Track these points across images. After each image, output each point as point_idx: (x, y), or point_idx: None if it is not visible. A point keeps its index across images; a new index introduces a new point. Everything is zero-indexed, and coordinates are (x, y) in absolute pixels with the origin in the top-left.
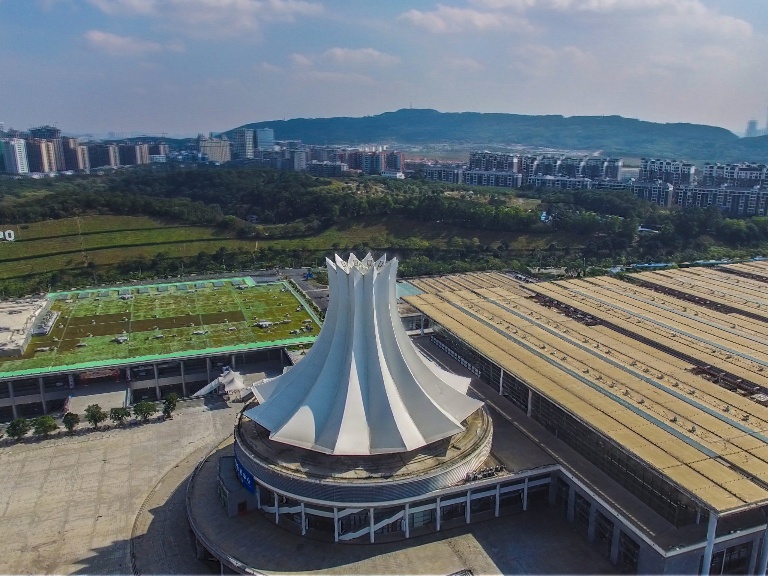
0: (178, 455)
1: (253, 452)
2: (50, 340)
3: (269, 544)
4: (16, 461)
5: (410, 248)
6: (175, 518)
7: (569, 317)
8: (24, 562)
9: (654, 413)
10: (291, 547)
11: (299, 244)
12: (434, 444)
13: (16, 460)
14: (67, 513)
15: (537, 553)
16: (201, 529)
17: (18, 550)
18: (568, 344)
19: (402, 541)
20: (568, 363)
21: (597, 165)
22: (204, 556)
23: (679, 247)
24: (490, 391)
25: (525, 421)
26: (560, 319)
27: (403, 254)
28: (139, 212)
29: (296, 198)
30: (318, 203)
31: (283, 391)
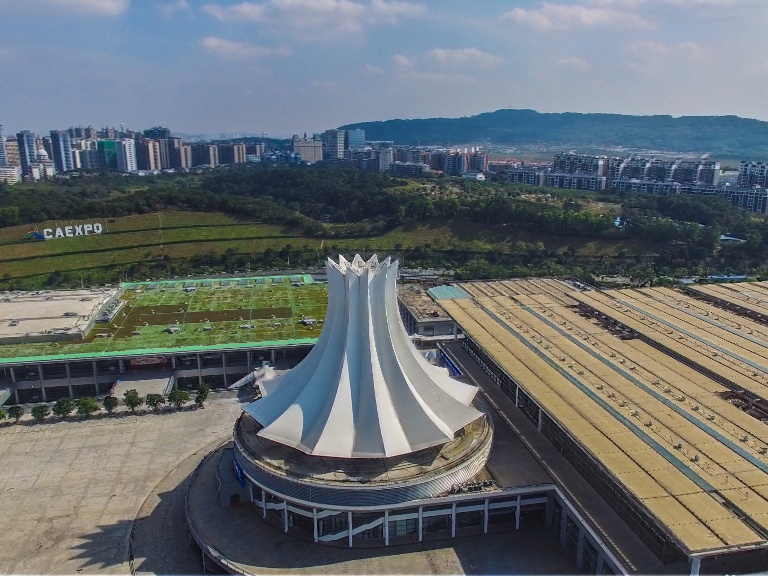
0: (199, 443)
1: (244, 446)
2: (110, 327)
3: (251, 538)
4: (56, 437)
5: (472, 251)
6: (179, 504)
7: (606, 329)
8: (37, 532)
9: (659, 437)
10: (270, 543)
11: (362, 244)
12: (421, 452)
13: (57, 436)
14: (86, 490)
15: (516, 575)
16: (192, 517)
17: (35, 520)
18: (592, 357)
19: (381, 548)
20: (584, 378)
21: (690, 168)
22: (195, 543)
23: (767, 259)
24: (507, 402)
25: (533, 436)
26: (594, 331)
27: (465, 257)
28: (215, 209)
29: (368, 198)
30: (388, 203)
31: (281, 388)
